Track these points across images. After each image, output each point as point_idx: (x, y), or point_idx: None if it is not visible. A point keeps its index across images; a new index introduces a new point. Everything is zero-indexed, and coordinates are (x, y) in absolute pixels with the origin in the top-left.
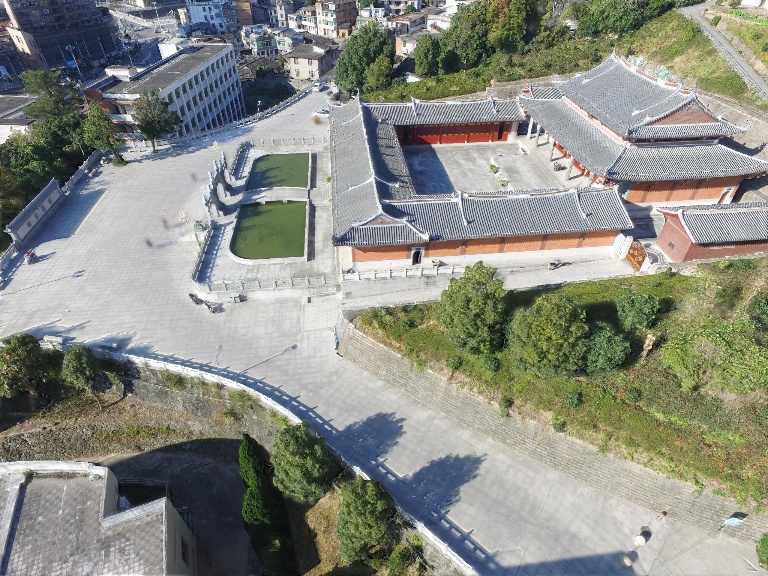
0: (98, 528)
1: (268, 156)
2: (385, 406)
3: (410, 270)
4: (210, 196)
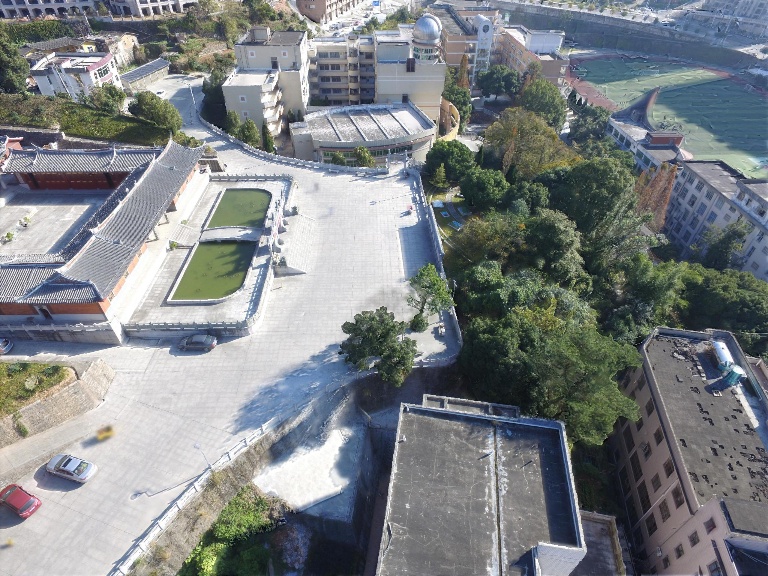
0: (315, 138)
1: None
2: None
3: None
4: None
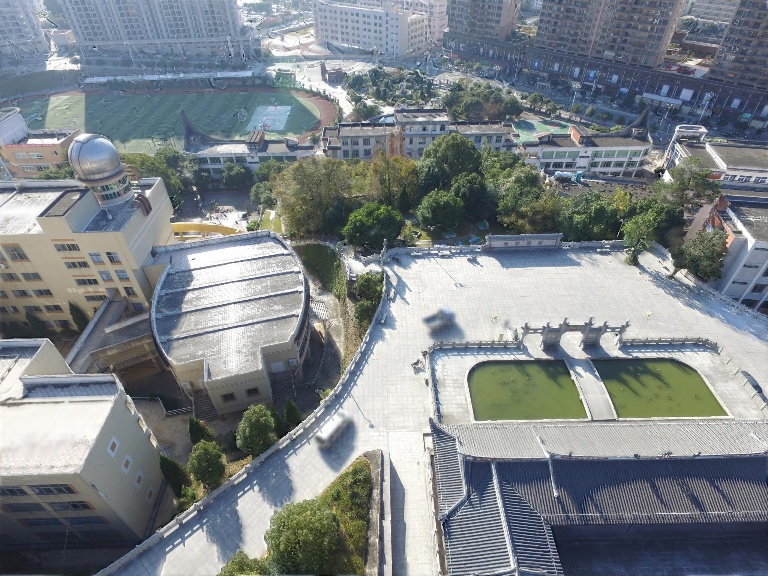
0: None
1: (694, 371)
2: (298, 494)
3: (435, 518)
4: (541, 328)
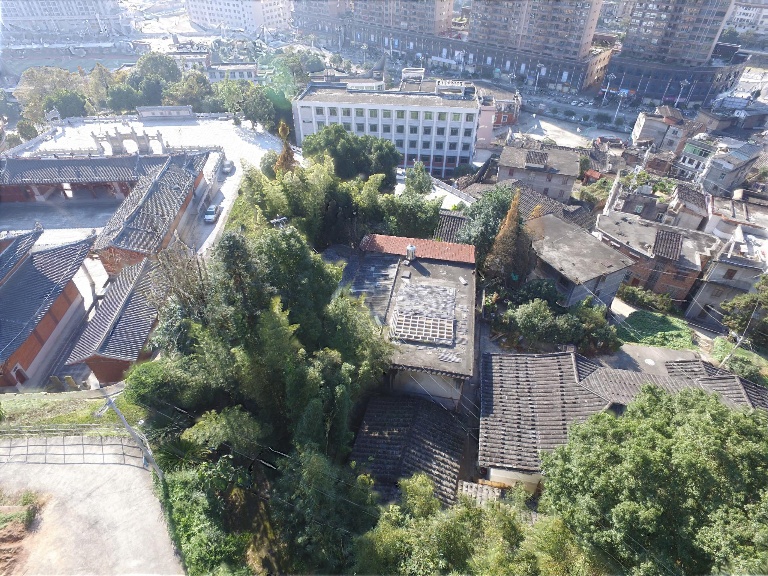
0: None
1: None
2: None
3: None
4: (104, 137)
